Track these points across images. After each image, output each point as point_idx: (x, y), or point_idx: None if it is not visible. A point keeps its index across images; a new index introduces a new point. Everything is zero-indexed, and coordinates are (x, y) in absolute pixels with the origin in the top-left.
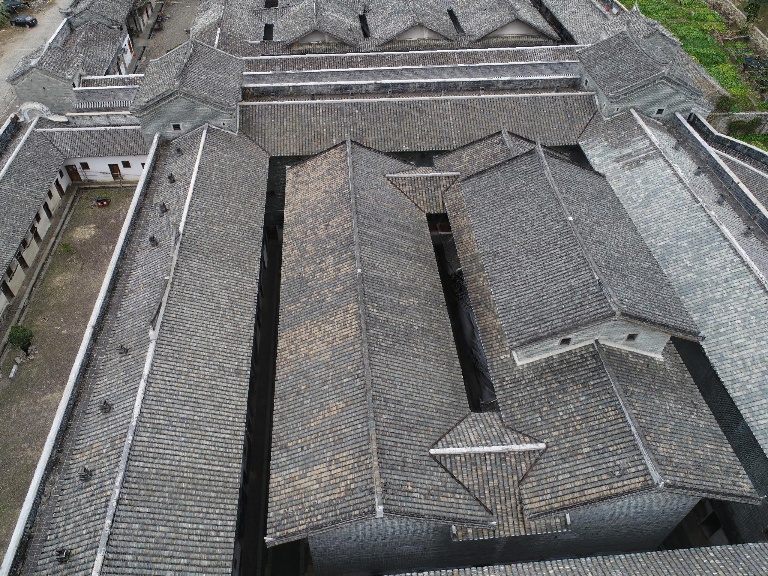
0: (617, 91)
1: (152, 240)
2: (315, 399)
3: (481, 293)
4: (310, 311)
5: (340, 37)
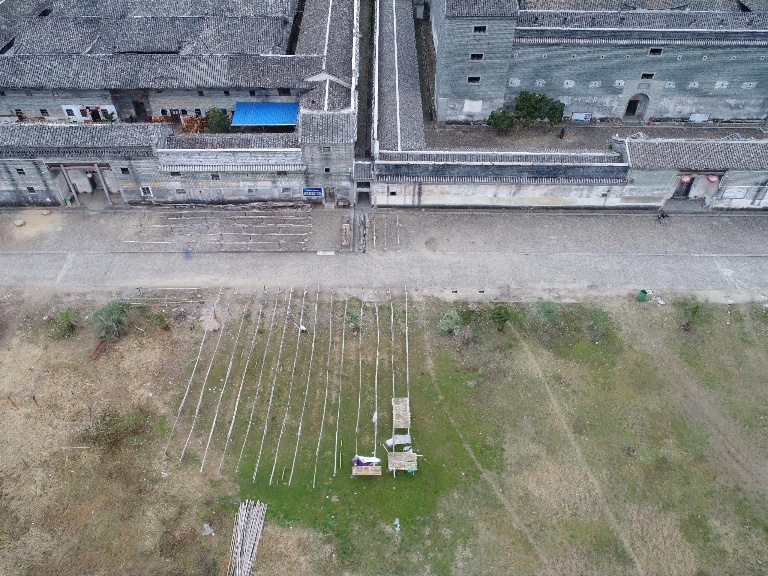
0: None
1: (623, 19)
2: (687, 0)
3: None
4: (642, 2)
5: (286, 18)
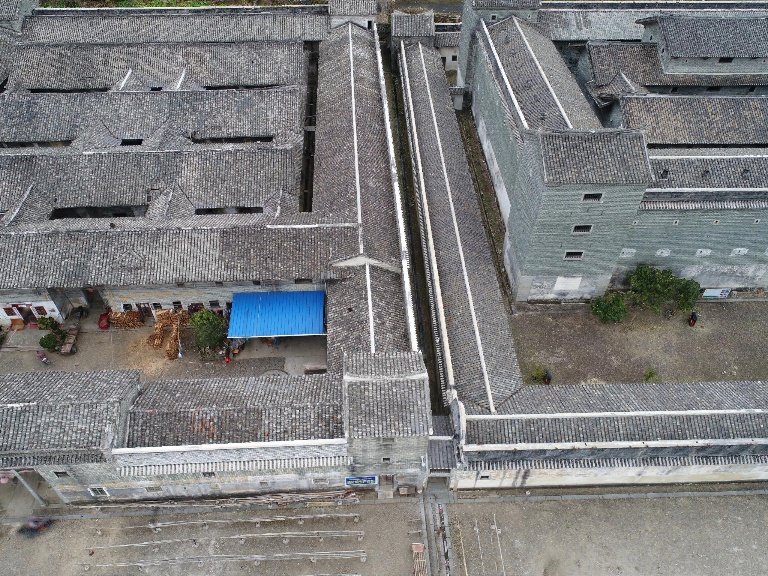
0: (540, 1)
1: None
2: None
3: (727, 80)
4: None
5: (296, 144)
